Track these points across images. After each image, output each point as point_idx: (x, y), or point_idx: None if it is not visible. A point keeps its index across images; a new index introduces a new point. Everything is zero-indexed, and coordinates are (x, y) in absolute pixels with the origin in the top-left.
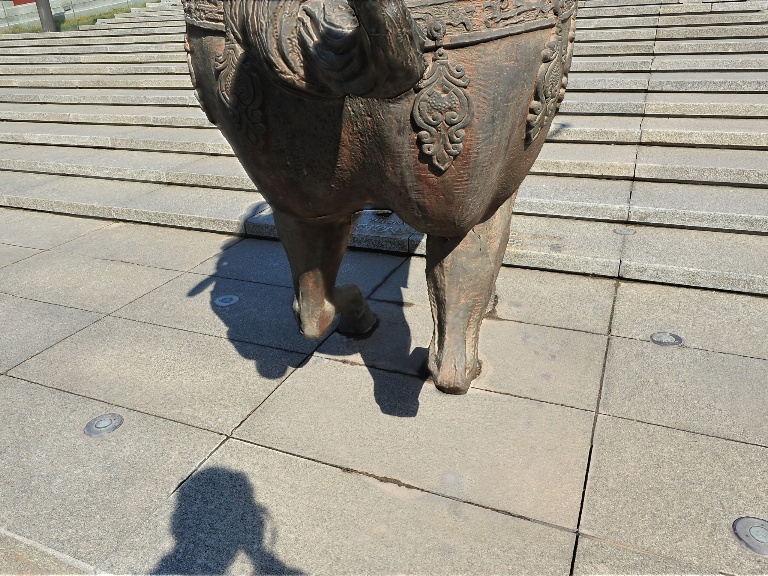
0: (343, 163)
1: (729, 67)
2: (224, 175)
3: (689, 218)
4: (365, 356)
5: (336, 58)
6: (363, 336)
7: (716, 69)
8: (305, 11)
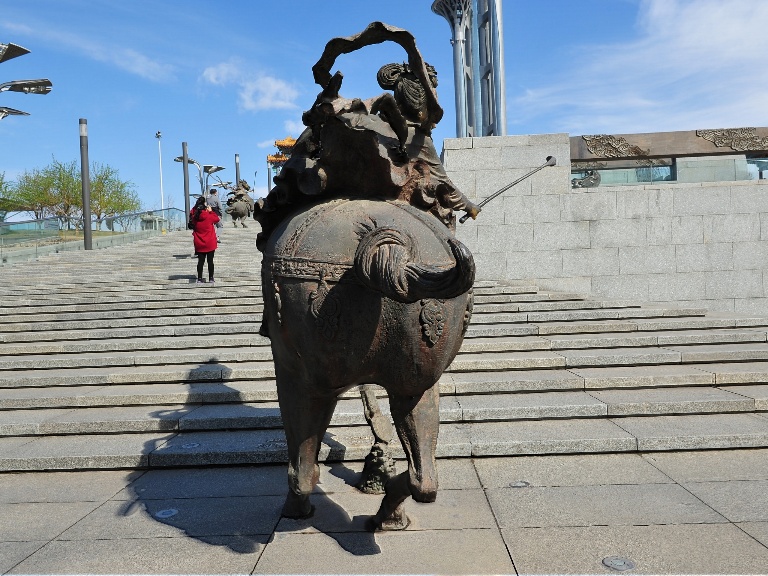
0: (374, 347)
1: (488, 321)
2: (109, 420)
3: (502, 413)
4: (318, 527)
5: (434, 283)
6: (307, 516)
7: (481, 323)
8: (407, 267)
